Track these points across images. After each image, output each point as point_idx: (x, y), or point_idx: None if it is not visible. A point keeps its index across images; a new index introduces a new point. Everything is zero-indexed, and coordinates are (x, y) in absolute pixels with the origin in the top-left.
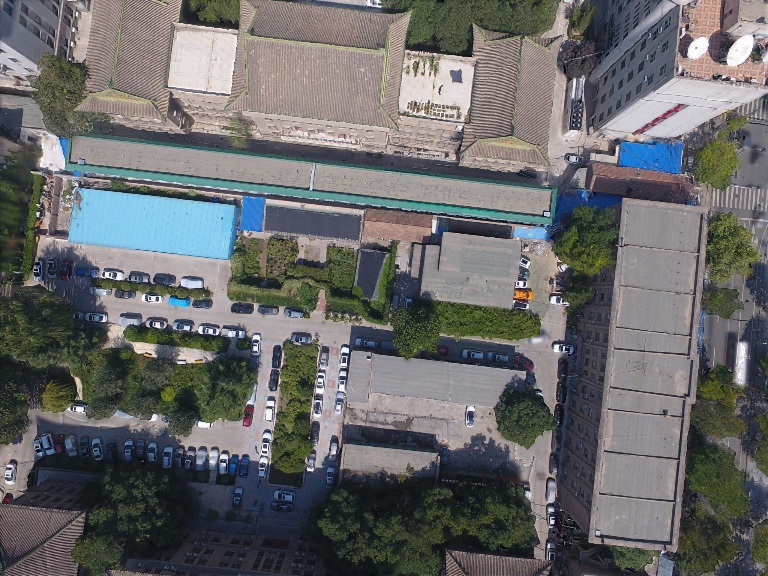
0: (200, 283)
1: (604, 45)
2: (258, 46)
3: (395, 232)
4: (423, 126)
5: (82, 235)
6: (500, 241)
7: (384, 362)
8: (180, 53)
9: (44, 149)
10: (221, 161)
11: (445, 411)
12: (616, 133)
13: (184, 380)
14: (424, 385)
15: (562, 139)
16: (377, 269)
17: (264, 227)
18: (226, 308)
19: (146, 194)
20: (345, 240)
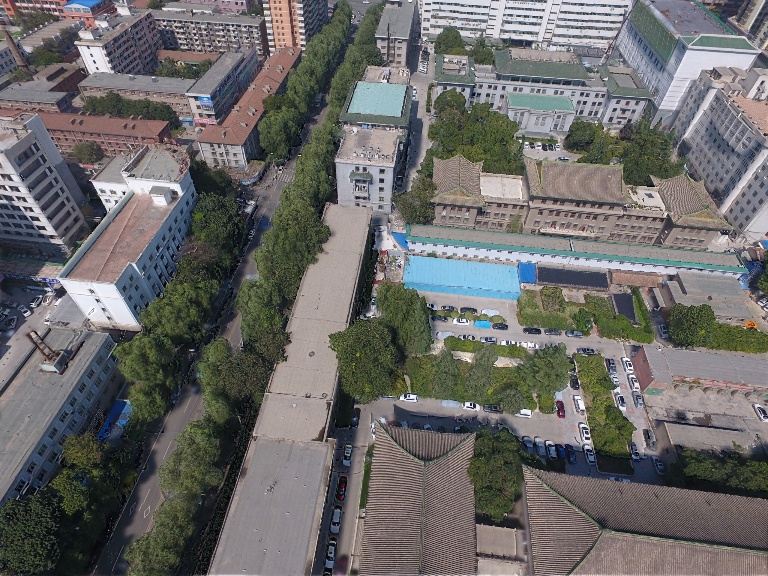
0: (498, 312)
1: (721, 195)
2: (550, 166)
3: (636, 280)
4: (641, 215)
5: (413, 278)
6: (720, 276)
7: (672, 353)
8: (484, 184)
9: (376, 241)
10: (508, 238)
11: (735, 410)
12: (754, 235)
13: (498, 378)
14: (714, 370)
15: (717, 244)
16: (631, 303)
17: (538, 280)
18: (519, 331)
19: (453, 259)
20: (598, 288)
